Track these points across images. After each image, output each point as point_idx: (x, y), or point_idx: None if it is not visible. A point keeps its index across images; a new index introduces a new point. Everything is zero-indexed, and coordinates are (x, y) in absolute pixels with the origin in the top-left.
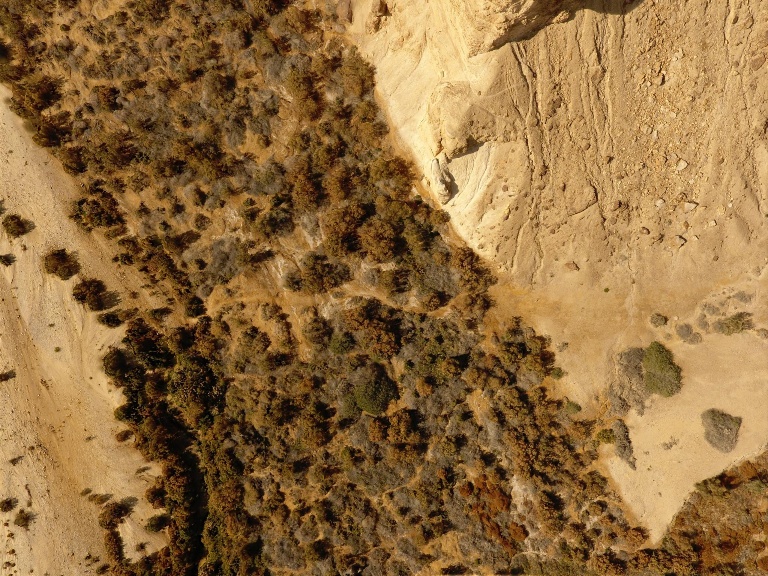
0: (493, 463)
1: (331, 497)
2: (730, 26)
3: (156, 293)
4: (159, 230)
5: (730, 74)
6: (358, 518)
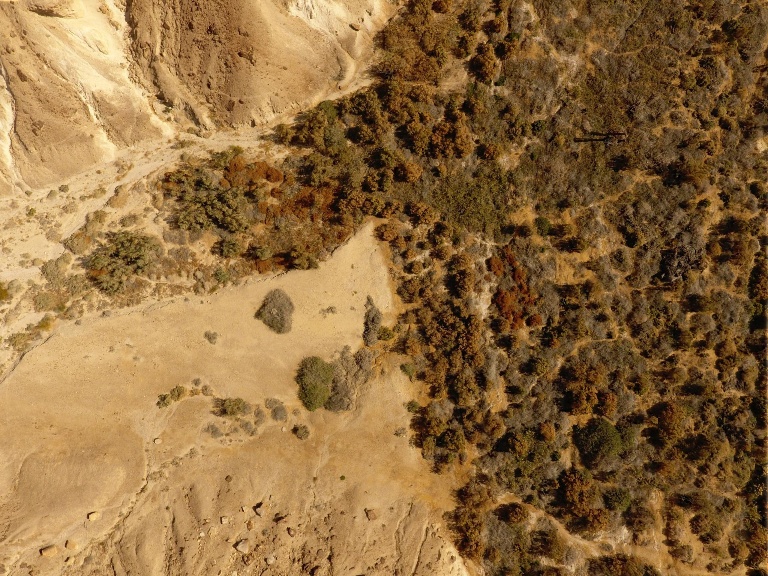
0: (501, 338)
1: None
2: None
3: None
4: None
5: None
6: (650, 325)
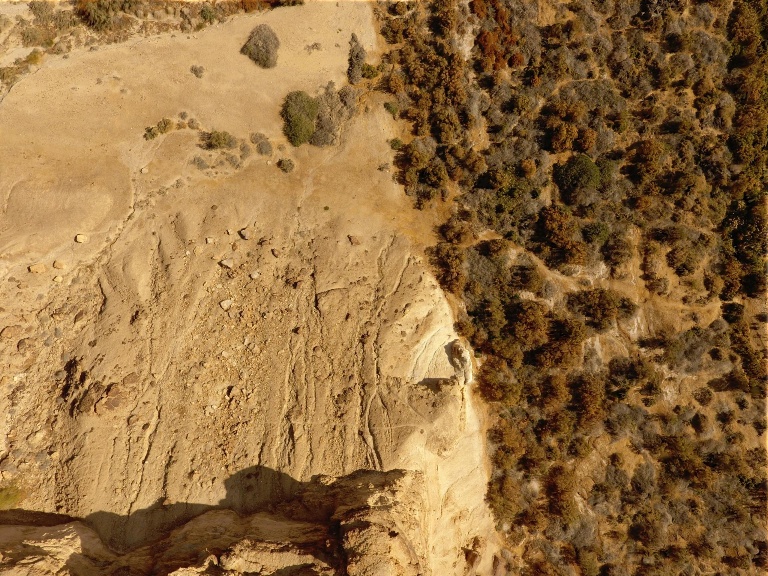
0: (483, 78)
1: (650, 90)
2: (152, 423)
3: (767, 339)
4: (749, 402)
5: (161, 377)
6: (630, 63)
